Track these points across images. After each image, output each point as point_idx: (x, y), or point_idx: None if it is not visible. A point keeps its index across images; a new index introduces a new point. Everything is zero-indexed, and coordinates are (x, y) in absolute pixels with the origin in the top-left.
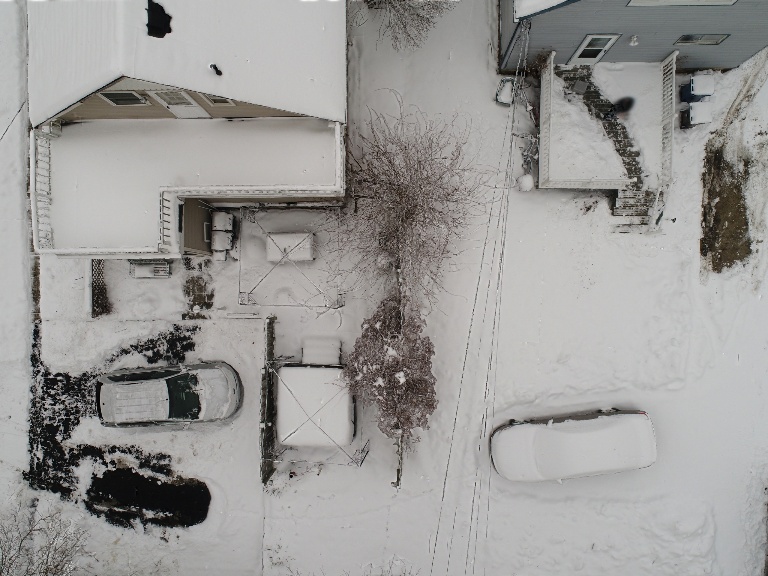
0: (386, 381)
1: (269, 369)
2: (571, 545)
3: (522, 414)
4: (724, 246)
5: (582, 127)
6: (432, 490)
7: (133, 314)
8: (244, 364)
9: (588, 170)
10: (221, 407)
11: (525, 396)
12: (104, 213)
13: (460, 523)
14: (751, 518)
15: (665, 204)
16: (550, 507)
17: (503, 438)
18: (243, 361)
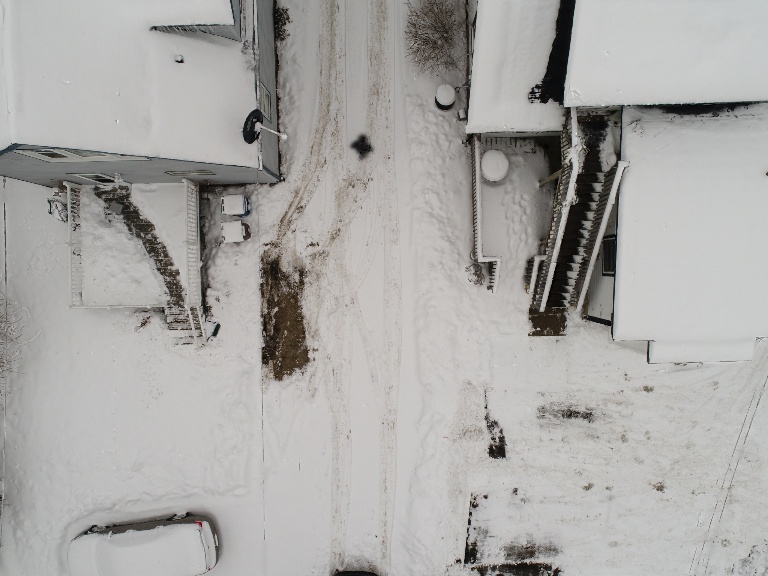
0: None
1: None
2: None
3: (104, 520)
4: (284, 354)
5: (116, 249)
6: None
7: None
8: None
9: (122, 292)
10: None
11: (102, 504)
12: None
13: None
14: None
15: None
16: None
17: (71, 548)
18: None
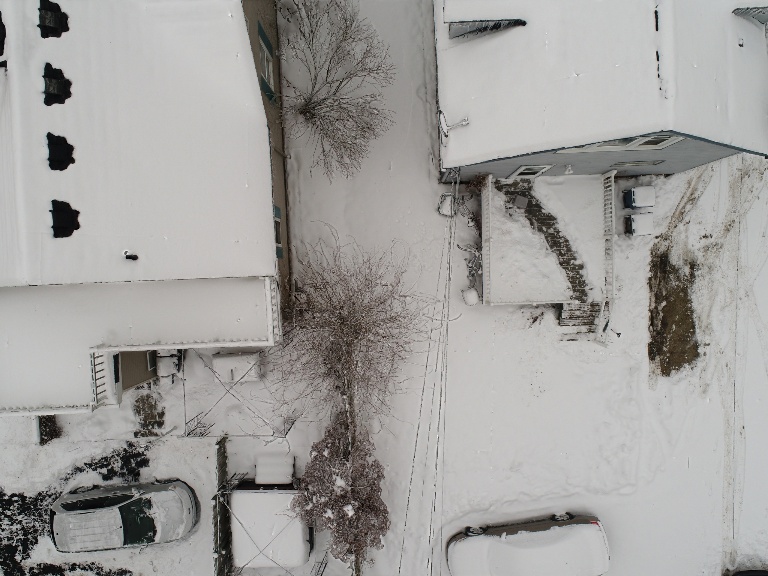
0: (335, 512)
1: (220, 498)
2: None
3: (477, 521)
4: (672, 350)
5: (524, 244)
6: None
7: (84, 437)
8: (199, 479)
9: (531, 288)
10: (177, 529)
11: (479, 505)
12: (37, 369)
13: None
14: None
15: (609, 321)
16: None
17: (458, 551)
18: (198, 476)
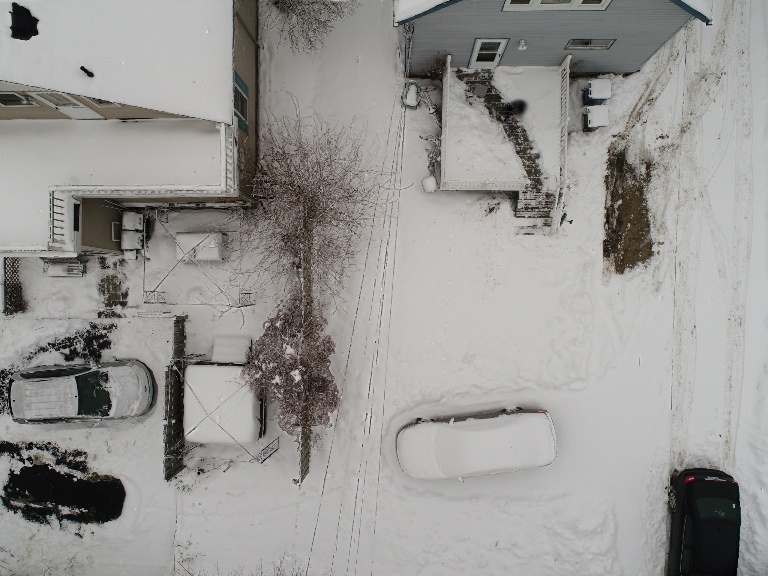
0: (283, 379)
1: (173, 367)
2: (475, 543)
3: (429, 413)
4: (626, 248)
5: (481, 130)
6: (340, 488)
7: (48, 312)
8: (158, 362)
9: (487, 172)
10: (131, 404)
11: (431, 395)
12: None
13: (367, 520)
14: (651, 517)
15: (561, 206)
16: (455, 505)
17: (406, 436)
18: (157, 359)
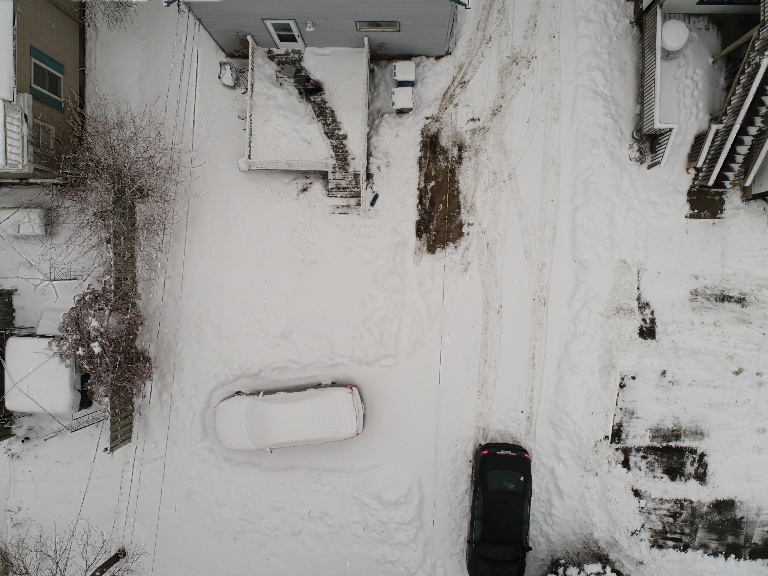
0: (86, 351)
1: None
2: (290, 512)
3: (248, 386)
4: (438, 228)
5: (288, 110)
6: (162, 457)
7: None
8: None
9: (292, 152)
10: None
11: (249, 369)
12: None
13: (187, 489)
14: (456, 489)
15: None
16: (271, 475)
17: (220, 408)
18: None
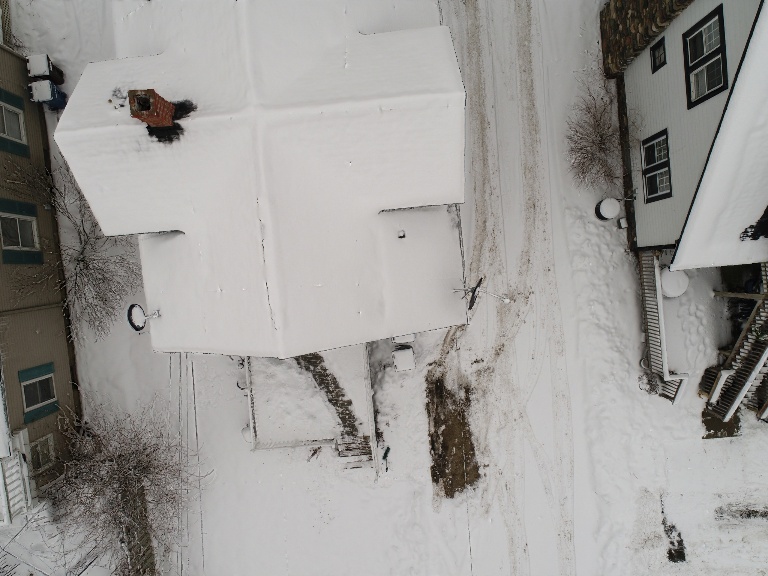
0: None
1: None
2: None
3: None
4: (454, 472)
5: (289, 386)
6: None
7: None
8: None
9: (298, 429)
10: None
11: None
12: None
13: None
14: None
15: None
16: None
17: None
18: None
